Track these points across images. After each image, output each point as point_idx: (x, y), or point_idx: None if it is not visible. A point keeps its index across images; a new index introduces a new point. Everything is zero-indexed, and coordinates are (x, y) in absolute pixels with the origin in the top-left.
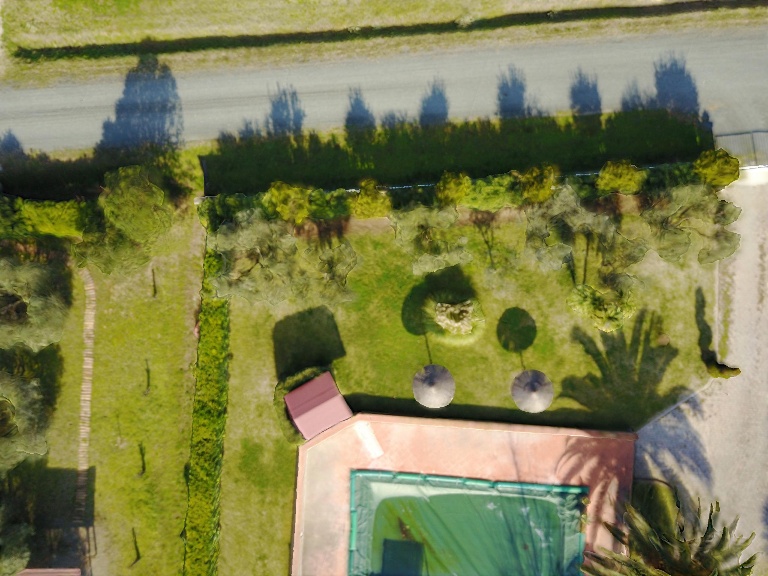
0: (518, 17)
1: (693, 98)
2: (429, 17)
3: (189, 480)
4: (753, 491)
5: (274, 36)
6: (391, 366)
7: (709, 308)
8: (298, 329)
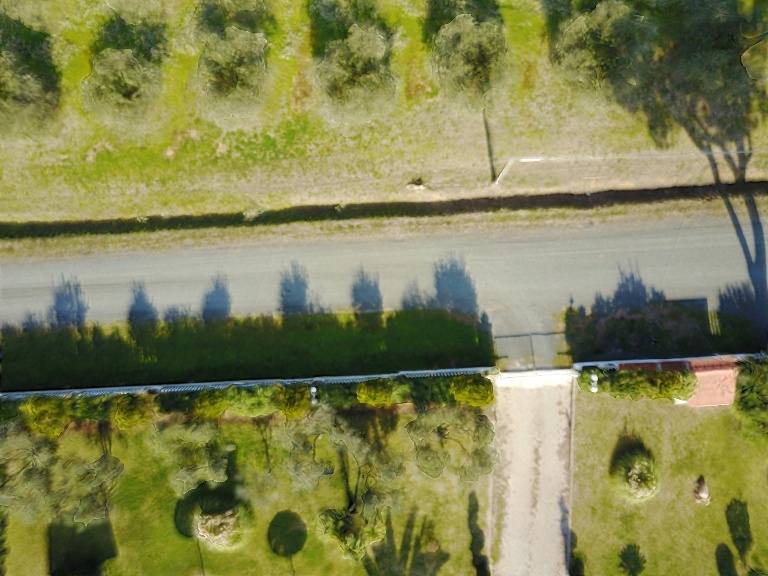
0: (307, 209)
1: (473, 299)
2: (218, 208)
3: None
4: None
5: (65, 223)
6: (162, 567)
7: (482, 512)
8: (74, 525)
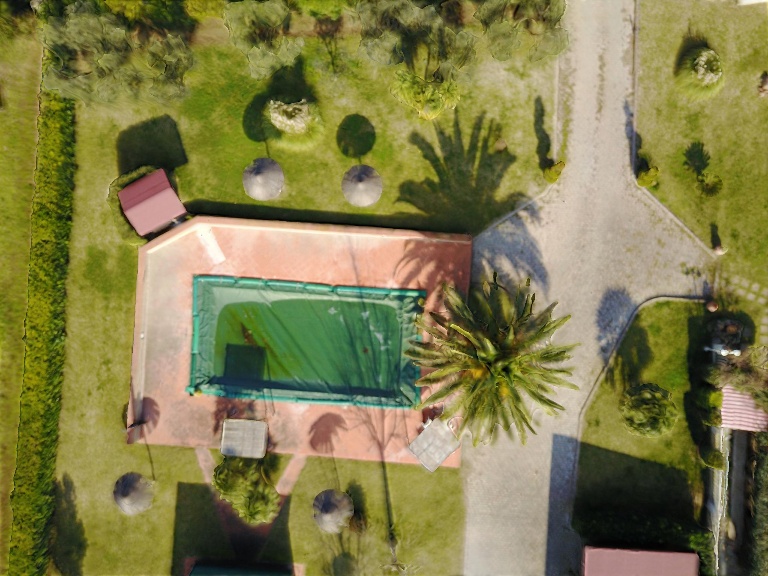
0: None
1: None
2: None
3: (28, 281)
4: (587, 295)
5: None
6: (232, 172)
7: (548, 117)
8: (141, 138)
